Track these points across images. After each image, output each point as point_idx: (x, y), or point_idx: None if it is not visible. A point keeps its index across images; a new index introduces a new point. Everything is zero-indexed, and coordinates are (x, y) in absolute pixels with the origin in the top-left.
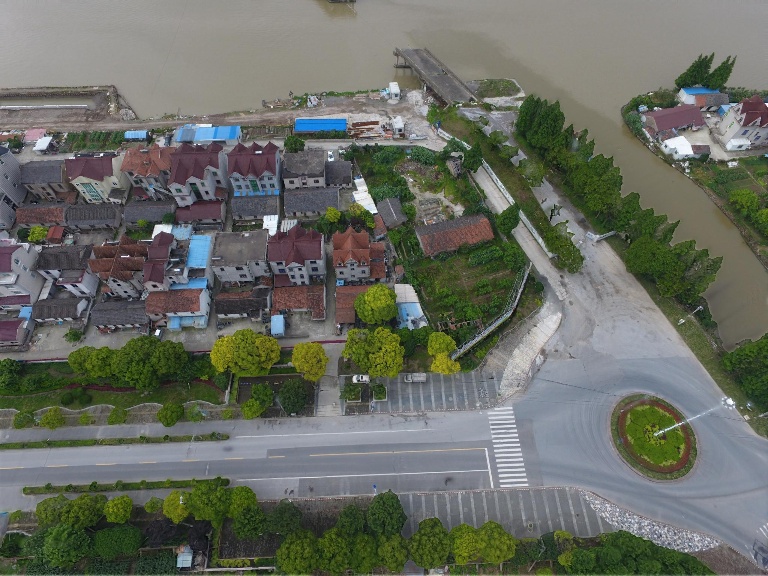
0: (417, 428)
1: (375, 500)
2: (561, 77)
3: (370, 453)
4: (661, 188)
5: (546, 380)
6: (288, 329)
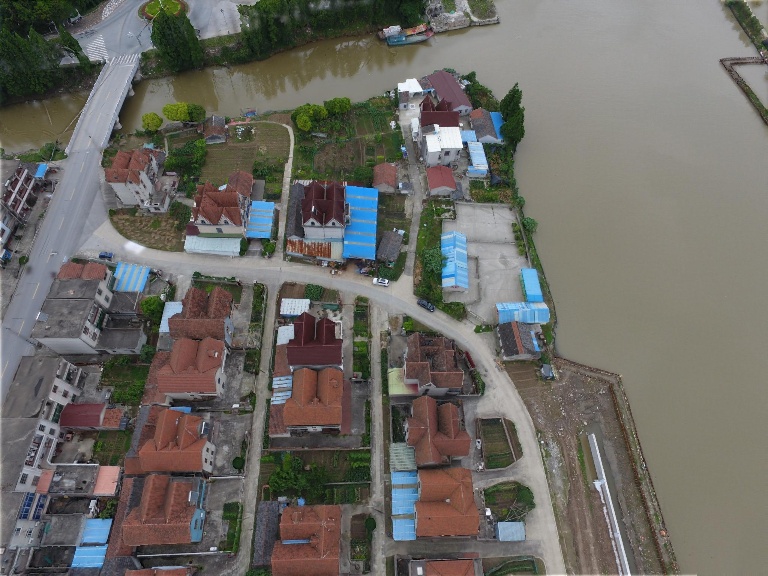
0: None
1: None
2: (511, 50)
3: None
4: (373, 89)
5: None
6: None
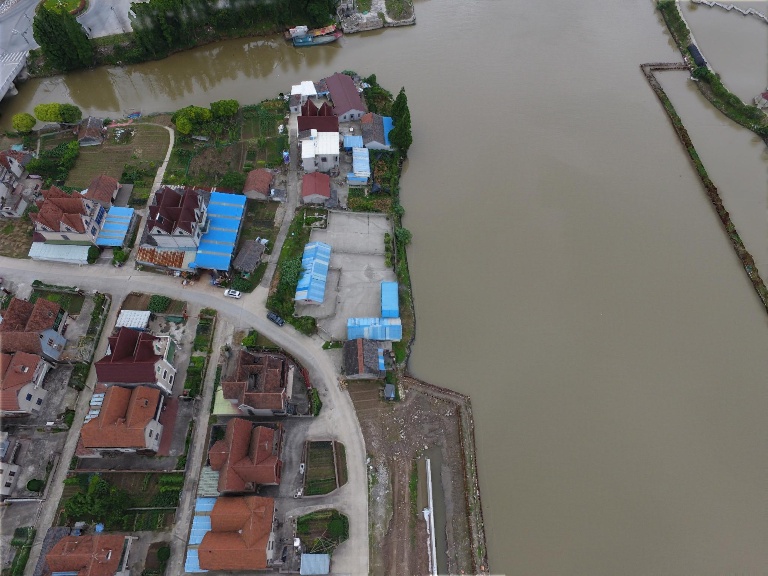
0: None
1: None
2: (422, 52)
3: None
4: (272, 91)
5: None
6: None
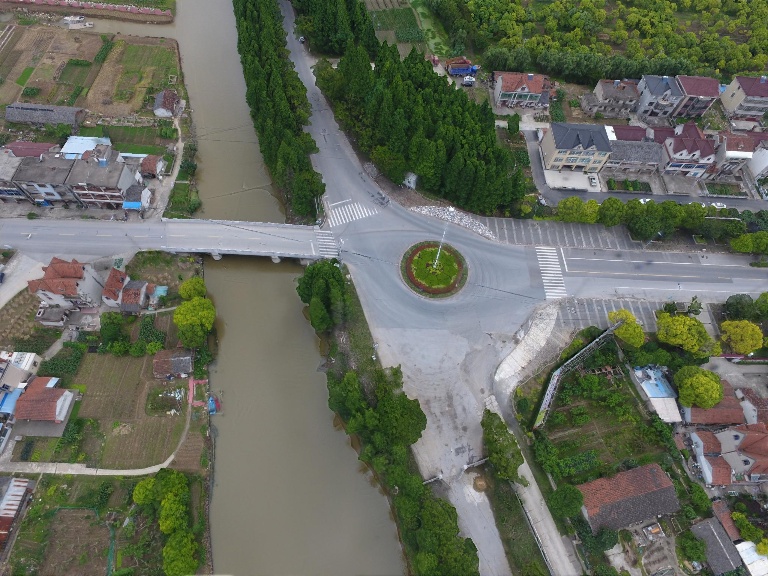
0: (623, 289)
1: (658, 230)
2: None
3: (655, 275)
4: None
5: (533, 298)
6: (767, 383)
